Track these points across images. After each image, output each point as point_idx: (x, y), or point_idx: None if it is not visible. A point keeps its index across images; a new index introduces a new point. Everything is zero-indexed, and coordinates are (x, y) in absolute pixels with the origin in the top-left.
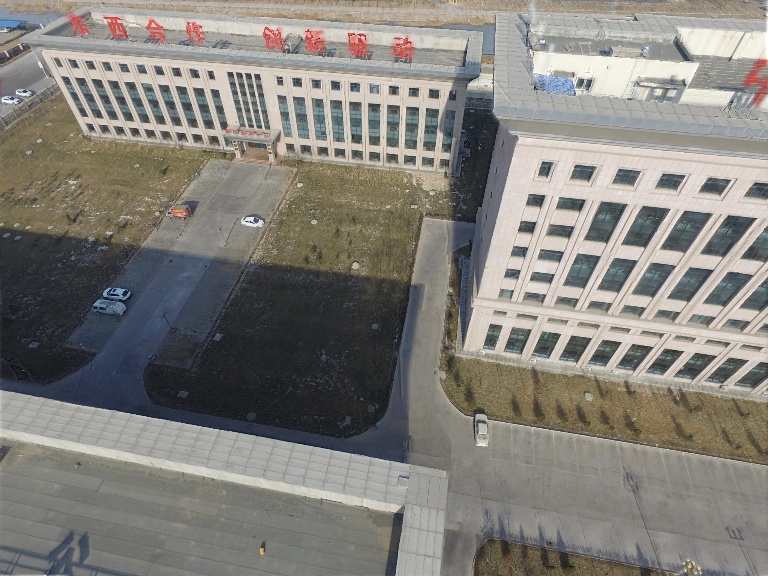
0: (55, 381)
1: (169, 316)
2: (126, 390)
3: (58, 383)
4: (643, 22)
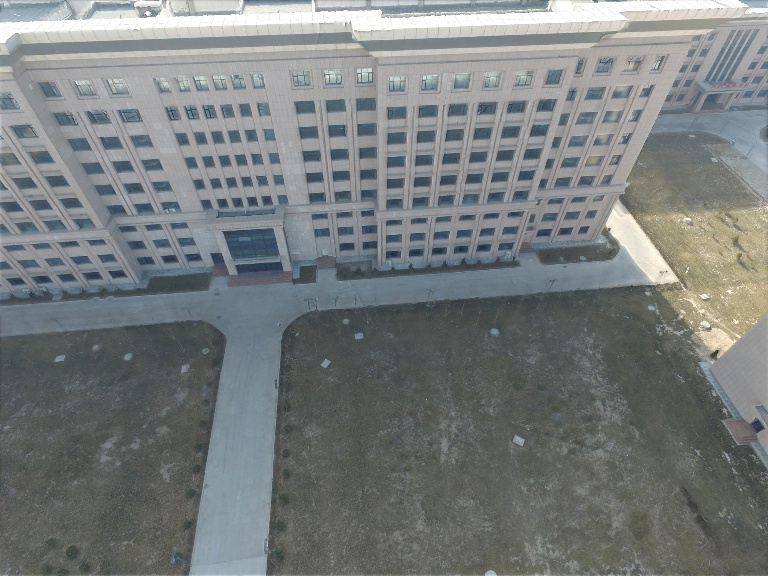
0: (762, 129)
1: (760, 163)
2: (722, 133)
3: (759, 129)
4: (614, 10)
